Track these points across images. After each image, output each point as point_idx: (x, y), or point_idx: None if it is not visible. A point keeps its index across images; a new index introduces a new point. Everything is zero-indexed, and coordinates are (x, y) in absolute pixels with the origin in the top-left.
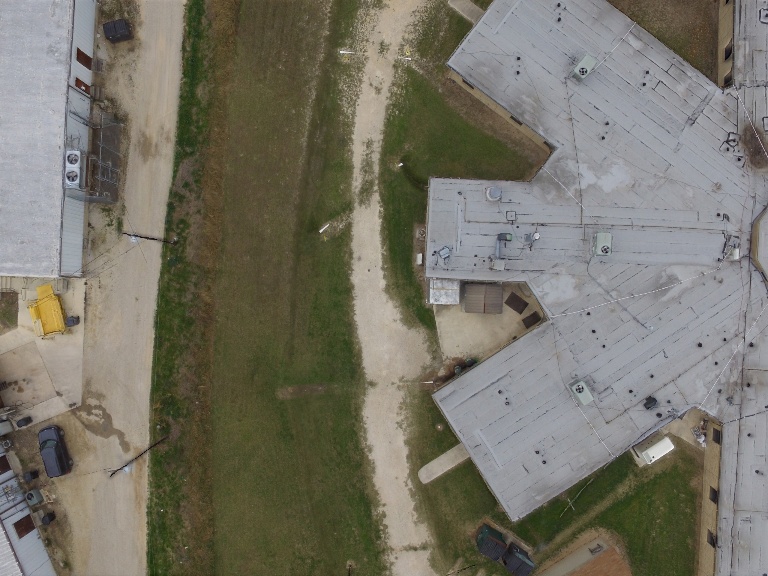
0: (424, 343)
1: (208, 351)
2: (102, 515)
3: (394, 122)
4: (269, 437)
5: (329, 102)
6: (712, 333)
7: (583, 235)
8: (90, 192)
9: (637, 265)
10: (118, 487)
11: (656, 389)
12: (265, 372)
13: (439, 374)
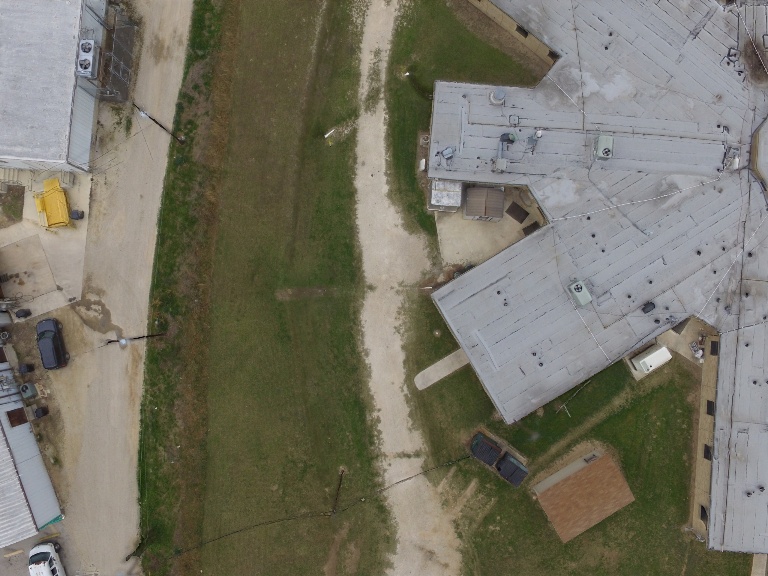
0: (424, 249)
1: (210, 249)
2: (96, 411)
3: (402, 33)
4: (267, 338)
5: (339, 12)
6: (711, 243)
7: (585, 141)
8: (101, 89)
9: (637, 173)
10: (113, 383)
11: (654, 296)
12: (265, 272)
13: (438, 280)
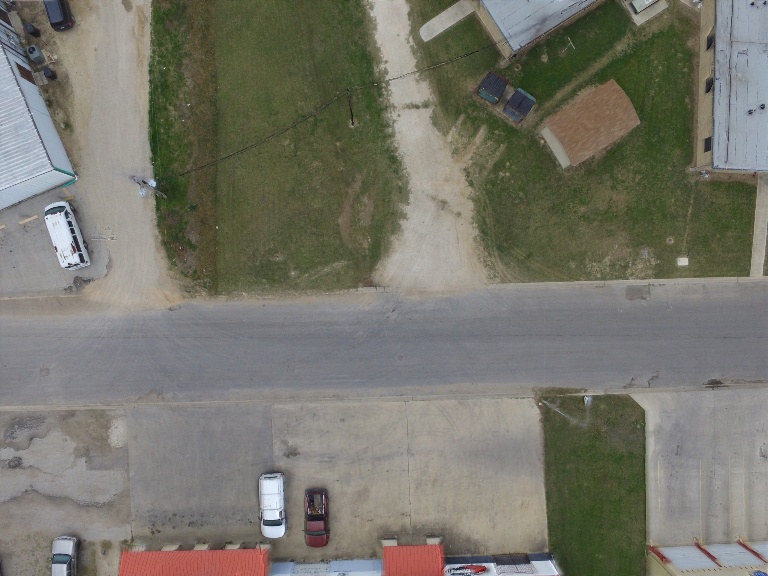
0: None
1: None
2: (104, 74)
3: None
4: None
5: None
6: None
7: None
8: None
9: None
10: (120, 46)
11: None
12: None
13: None
